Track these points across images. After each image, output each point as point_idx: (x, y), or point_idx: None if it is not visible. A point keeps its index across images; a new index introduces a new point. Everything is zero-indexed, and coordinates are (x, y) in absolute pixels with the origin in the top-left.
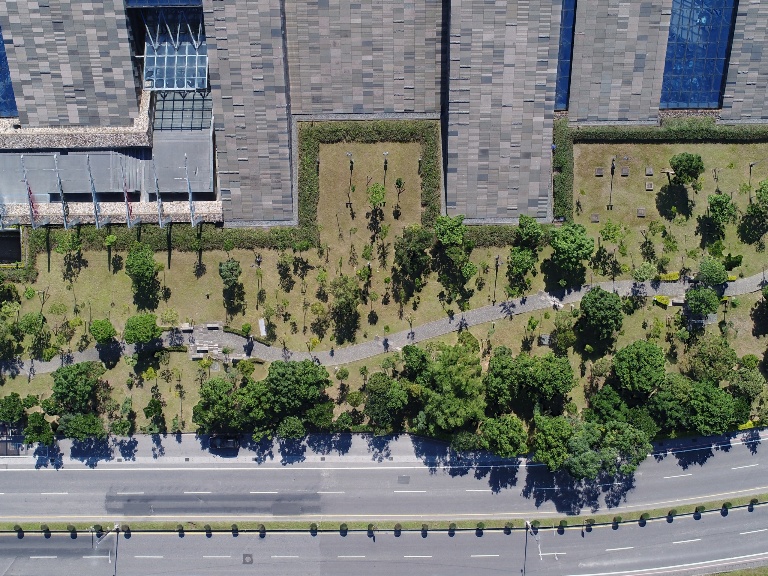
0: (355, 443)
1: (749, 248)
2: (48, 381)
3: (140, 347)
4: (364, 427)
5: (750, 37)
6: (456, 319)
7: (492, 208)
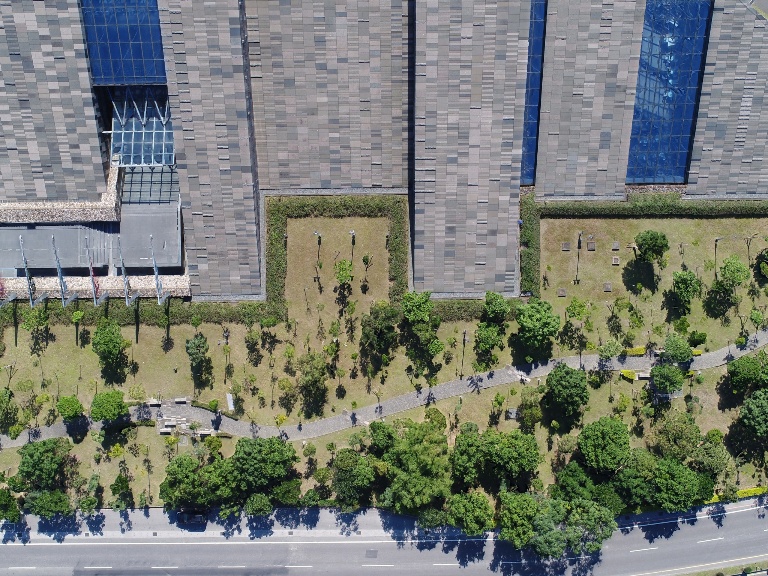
0: (323, 517)
1: (714, 322)
2: (15, 456)
3: (108, 421)
4: (332, 502)
5: (714, 116)
6: (424, 393)
7: (459, 283)
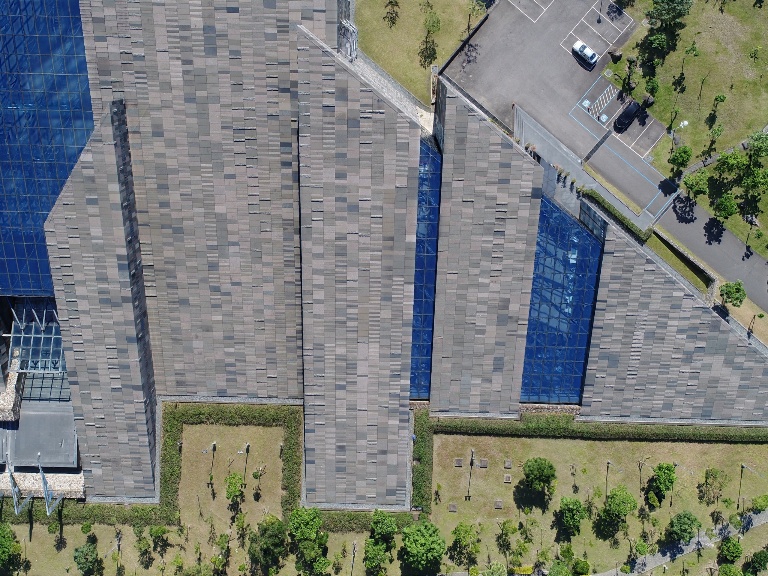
0: None
1: (603, 544)
2: None
3: None
4: None
5: (606, 347)
6: None
7: (351, 495)
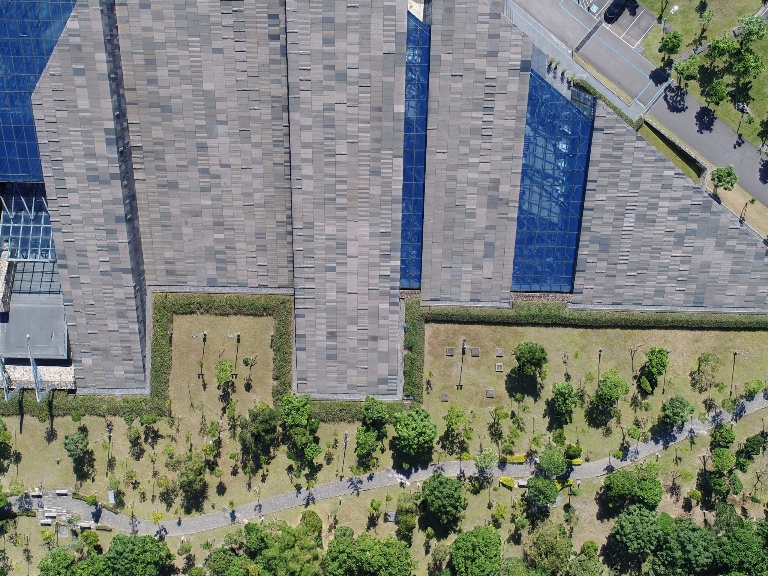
0: None
1: (596, 432)
2: None
3: None
4: None
5: (597, 230)
6: (303, 493)
7: (342, 384)
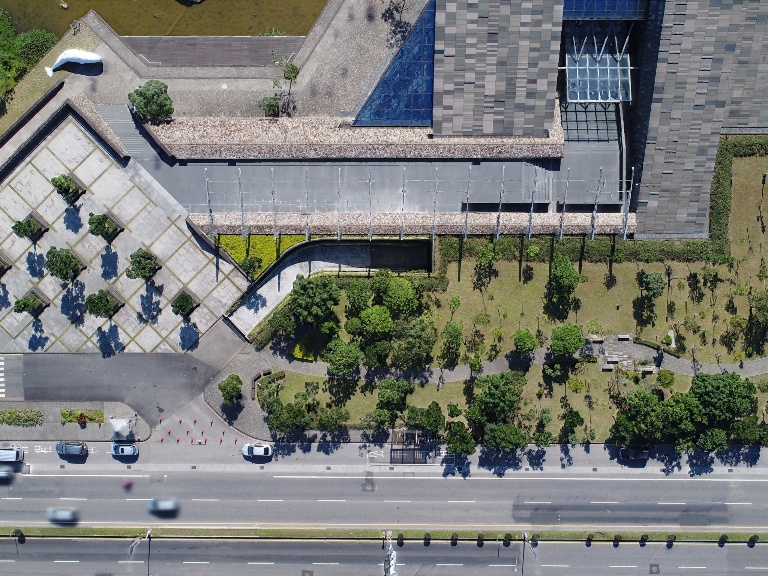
0: (763, 455)
1: None
2: (457, 390)
3: (550, 357)
4: None
5: None
6: None
7: None
